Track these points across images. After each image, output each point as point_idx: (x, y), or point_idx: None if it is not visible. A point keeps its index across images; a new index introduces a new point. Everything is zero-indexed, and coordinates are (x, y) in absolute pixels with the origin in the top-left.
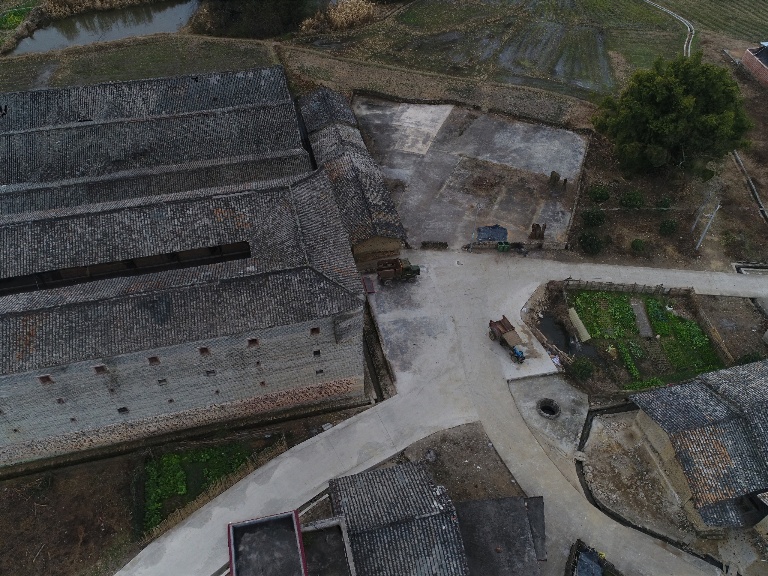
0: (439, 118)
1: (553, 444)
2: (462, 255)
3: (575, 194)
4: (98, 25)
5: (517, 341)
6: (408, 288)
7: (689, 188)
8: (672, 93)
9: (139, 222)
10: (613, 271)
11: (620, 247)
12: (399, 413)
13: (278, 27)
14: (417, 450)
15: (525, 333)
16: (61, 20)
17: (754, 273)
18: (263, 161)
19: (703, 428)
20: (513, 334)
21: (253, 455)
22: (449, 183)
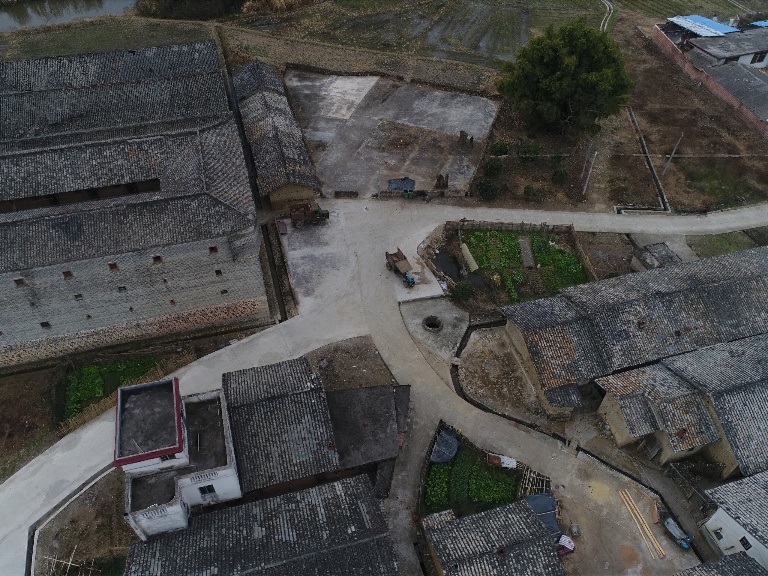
0: (364, 88)
1: (433, 352)
2: (371, 202)
3: (481, 151)
4: (49, 11)
5: (408, 268)
6: (318, 230)
7: (581, 142)
8: (557, 54)
9: (60, 162)
10: (506, 214)
11: (515, 194)
12: (298, 329)
13: (220, 9)
14: (311, 358)
15: (419, 264)
16: (12, 5)
17: (632, 213)
18: (188, 120)
19: (553, 327)
20: (405, 262)
21: (162, 361)
22: (367, 143)
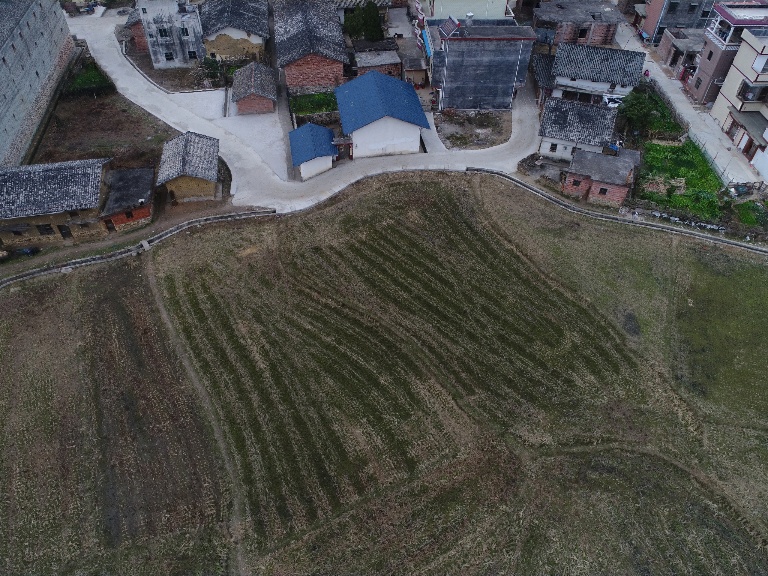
0: None
1: None
2: None
3: None
4: None
5: (83, 4)
6: None
7: None
8: None
9: None
10: None
11: None
12: None
13: None
14: (120, 37)
15: None
16: None
17: None
18: None
19: None
20: (78, 3)
21: None
22: None
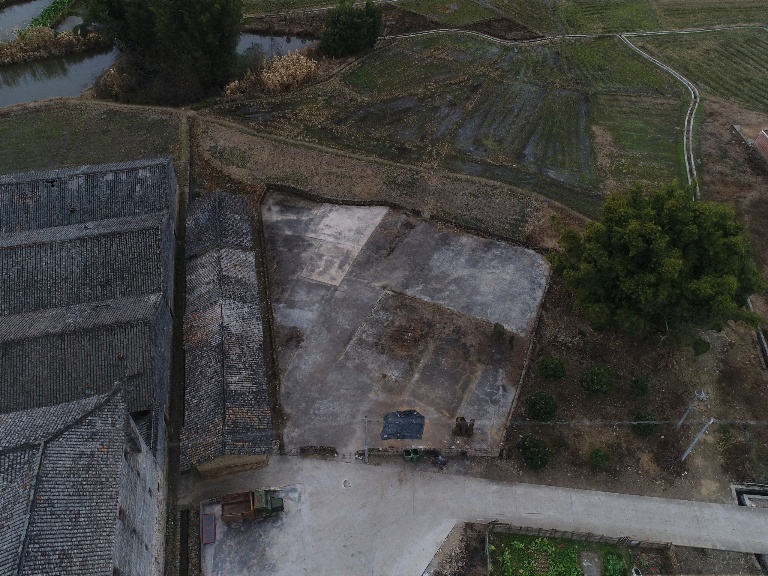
0: (366, 227)
1: None
2: (353, 468)
3: (525, 355)
4: (2, 80)
5: None
6: (265, 533)
7: (676, 359)
8: (651, 247)
9: None
10: (562, 499)
11: (576, 453)
12: None
13: (196, 92)
14: None
15: None
16: None
17: (762, 504)
18: (86, 331)
19: None
20: None
21: None
22: (360, 334)
